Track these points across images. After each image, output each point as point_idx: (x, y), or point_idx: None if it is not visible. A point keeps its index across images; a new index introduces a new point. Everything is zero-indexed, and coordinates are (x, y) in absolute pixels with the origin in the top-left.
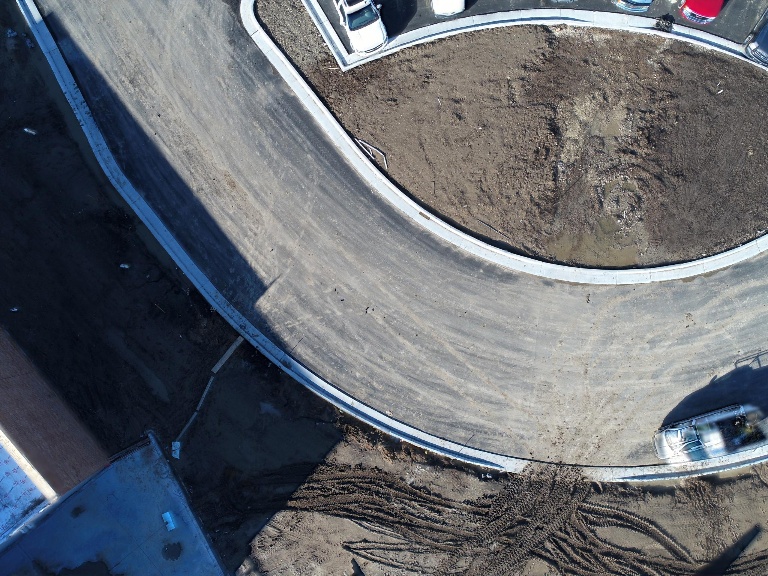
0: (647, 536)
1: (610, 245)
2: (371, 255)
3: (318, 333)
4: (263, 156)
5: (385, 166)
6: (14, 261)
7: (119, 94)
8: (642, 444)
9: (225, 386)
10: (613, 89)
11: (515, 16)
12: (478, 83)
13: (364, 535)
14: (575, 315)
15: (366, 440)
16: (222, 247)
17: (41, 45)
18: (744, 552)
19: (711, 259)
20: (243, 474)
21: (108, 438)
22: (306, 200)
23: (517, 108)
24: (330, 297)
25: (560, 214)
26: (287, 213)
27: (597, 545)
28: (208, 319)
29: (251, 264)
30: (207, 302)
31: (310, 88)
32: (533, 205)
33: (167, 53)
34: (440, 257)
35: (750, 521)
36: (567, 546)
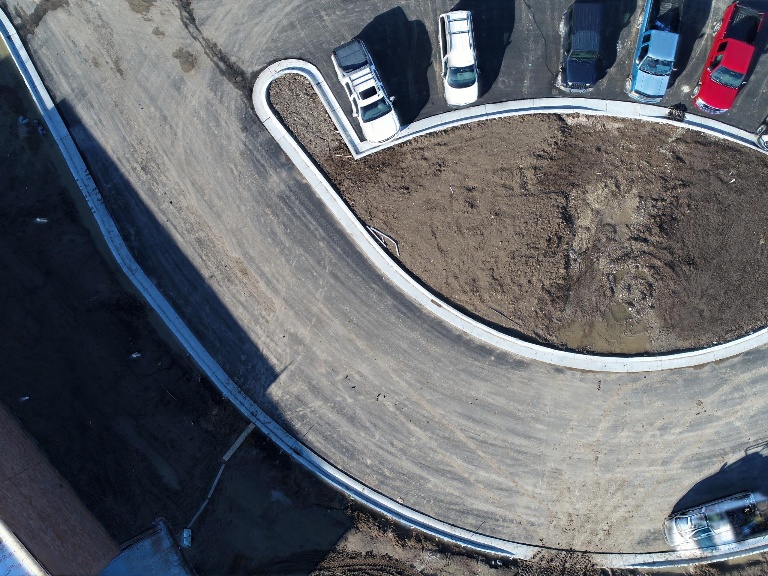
0: None
1: (621, 332)
2: (382, 342)
3: (329, 420)
4: (275, 243)
5: (397, 254)
6: (26, 348)
7: (131, 181)
8: (652, 531)
9: (236, 473)
10: (625, 177)
11: (527, 105)
12: (490, 172)
13: None
14: (586, 402)
15: (377, 527)
16: (234, 334)
17: (53, 132)
18: None
19: (722, 347)
20: (254, 561)
21: (120, 525)
22: (318, 287)
23: (529, 197)
24: (341, 384)
25: (571, 302)
26: (299, 300)
27: None
28: (220, 406)
29: (263, 351)
30: (219, 389)
31: (322, 176)
32: (545, 293)
33: (179, 140)
34: (451, 344)
35: None
36: None
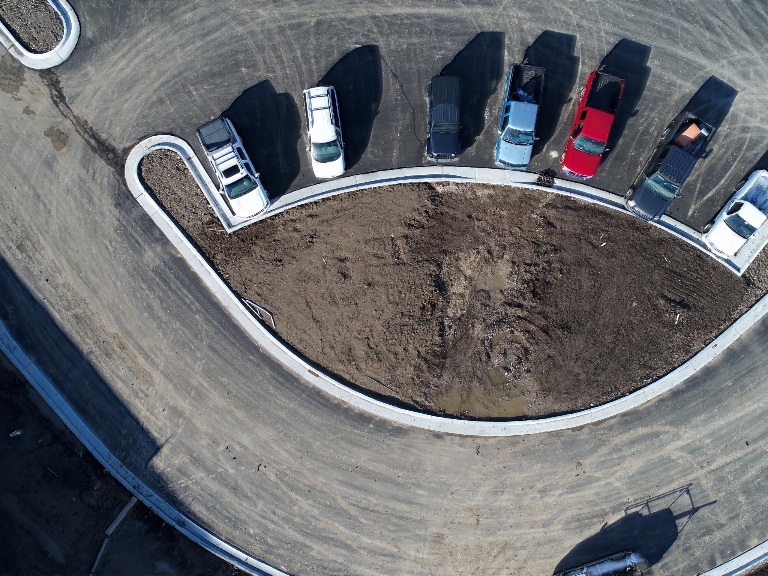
0: None
1: (499, 397)
2: (262, 413)
3: (211, 491)
4: (152, 318)
5: (273, 325)
6: None
7: (6, 260)
8: None
9: (119, 547)
10: (497, 243)
11: (397, 174)
12: (362, 242)
13: None
14: (465, 467)
15: None
16: (113, 409)
17: None
18: None
19: (599, 409)
20: None
21: None
22: (196, 360)
23: (402, 265)
24: (222, 455)
25: (448, 368)
26: (177, 373)
27: None
28: (101, 481)
29: (143, 425)
30: (100, 464)
31: (196, 250)
32: (421, 360)
33: (53, 218)
34: (330, 413)
35: None
36: None
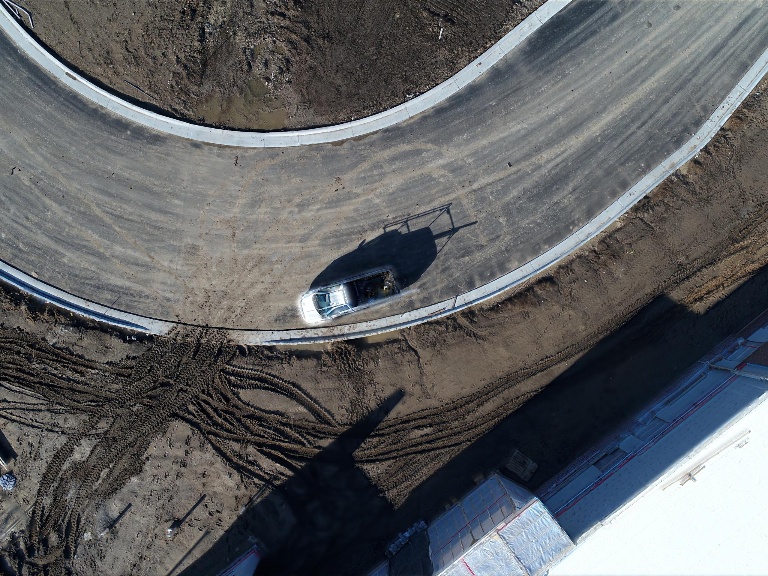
0: (290, 399)
1: (259, 108)
2: (18, 115)
3: None
4: None
5: (31, 25)
6: None
7: None
8: (289, 308)
9: None
10: None
11: None
12: None
13: (4, 395)
14: (223, 178)
15: (9, 300)
16: None
17: None
18: (388, 416)
19: (359, 123)
20: None
21: None
22: None
23: None
24: None
25: (208, 76)
26: None
27: (240, 408)
28: None
29: None
30: None
31: None
32: (180, 66)
33: None
34: (87, 118)
35: (395, 385)
36: (210, 408)
